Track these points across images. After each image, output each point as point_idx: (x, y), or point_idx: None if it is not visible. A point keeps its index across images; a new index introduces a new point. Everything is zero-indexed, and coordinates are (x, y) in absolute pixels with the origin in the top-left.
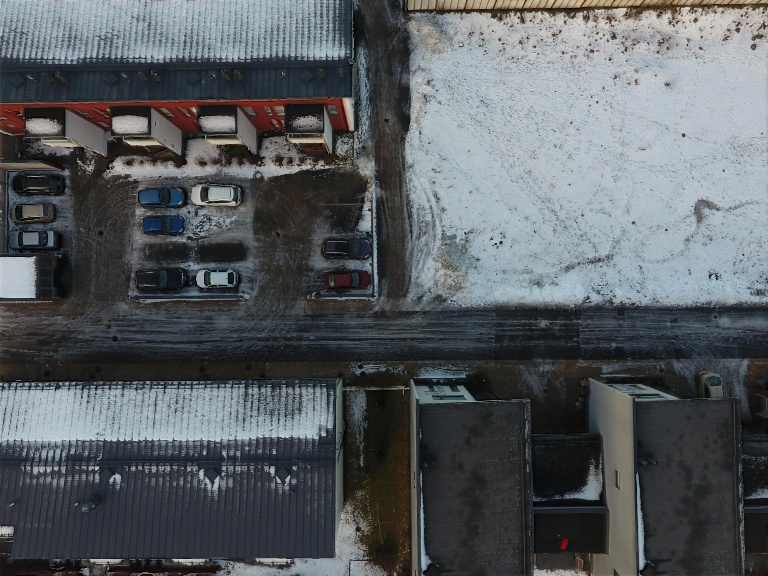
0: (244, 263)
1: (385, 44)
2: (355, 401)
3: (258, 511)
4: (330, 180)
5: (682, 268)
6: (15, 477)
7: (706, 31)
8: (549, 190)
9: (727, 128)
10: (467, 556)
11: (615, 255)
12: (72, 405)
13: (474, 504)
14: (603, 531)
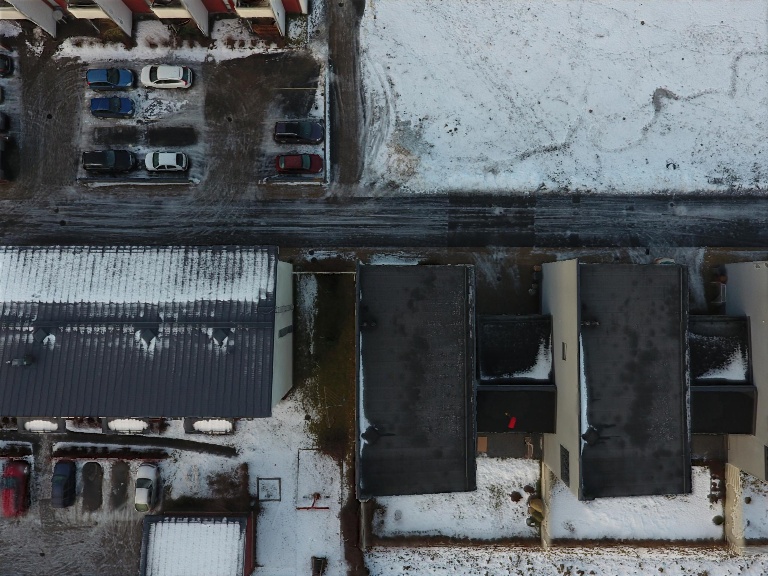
0: (195, 148)
1: None
2: (306, 288)
3: (194, 371)
4: (283, 64)
5: (639, 157)
6: None
7: None
8: (505, 77)
9: (687, 16)
10: (407, 420)
11: (572, 143)
12: (8, 268)
13: (415, 368)
14: (551, 409)
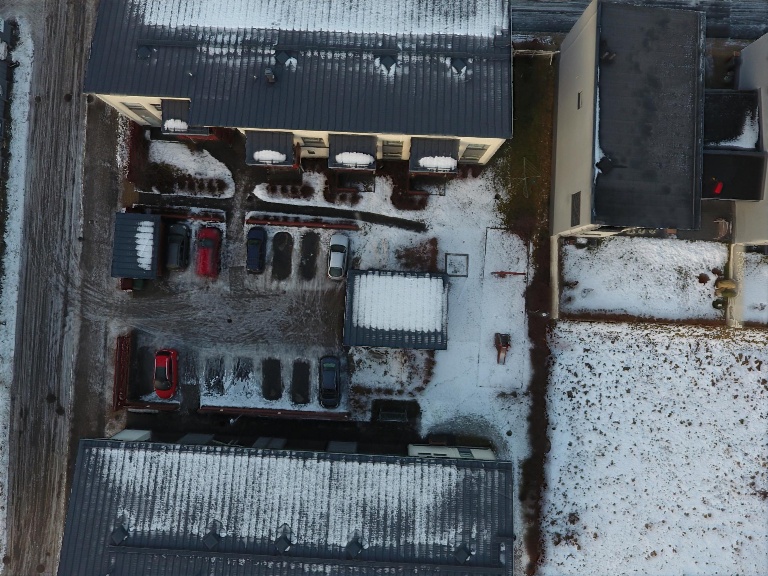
0: None
1: None
2: None
3: (434, 95)
4: None
5: None
6: (191, 56)
7: None
8: None
9: None
10: (639, 155)
11: None
12: None
13: (648, 105)
14: (758, 176)
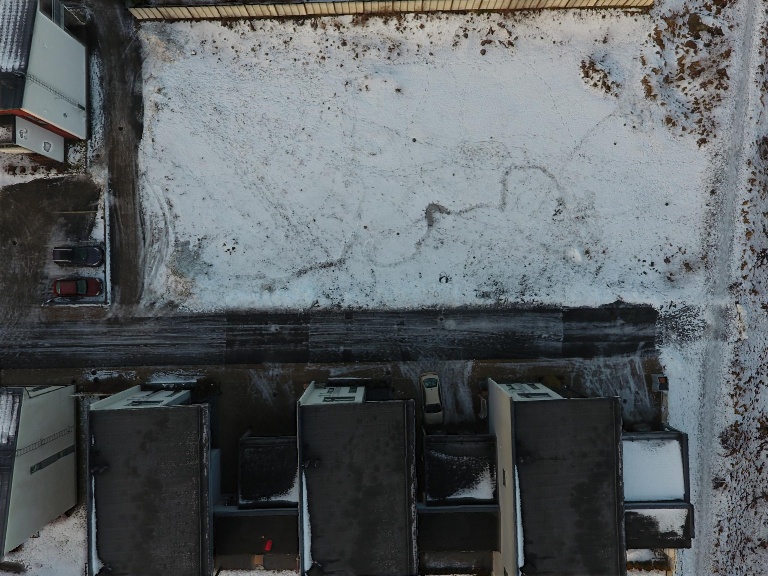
0: None
1: (118, 53)
2: None
3: None
4: (64, 188)
5: (413, 271)
6: None
7: (435, 37)
8: (281, 196)
9: (457, 132)
10: (141, 559)
11: (347, 259)
12: None
13: (149, 508)
14: None
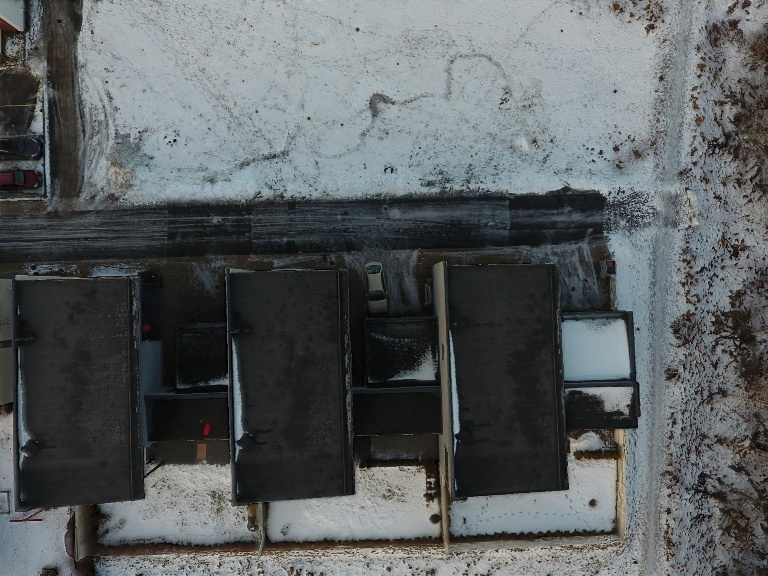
0: None
1: None
2: None
3: None
4: (3, 82)
5: (358, 162)
6: None
7: None
8: (223, 87)
9: (401, 21)
10: (69, 432)
11: (291, 151)
12: None
13: (77, 380)
14: None
